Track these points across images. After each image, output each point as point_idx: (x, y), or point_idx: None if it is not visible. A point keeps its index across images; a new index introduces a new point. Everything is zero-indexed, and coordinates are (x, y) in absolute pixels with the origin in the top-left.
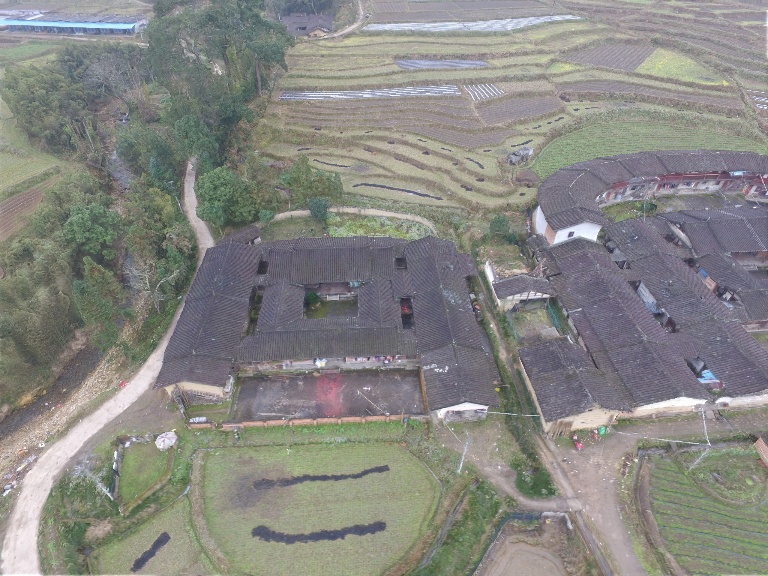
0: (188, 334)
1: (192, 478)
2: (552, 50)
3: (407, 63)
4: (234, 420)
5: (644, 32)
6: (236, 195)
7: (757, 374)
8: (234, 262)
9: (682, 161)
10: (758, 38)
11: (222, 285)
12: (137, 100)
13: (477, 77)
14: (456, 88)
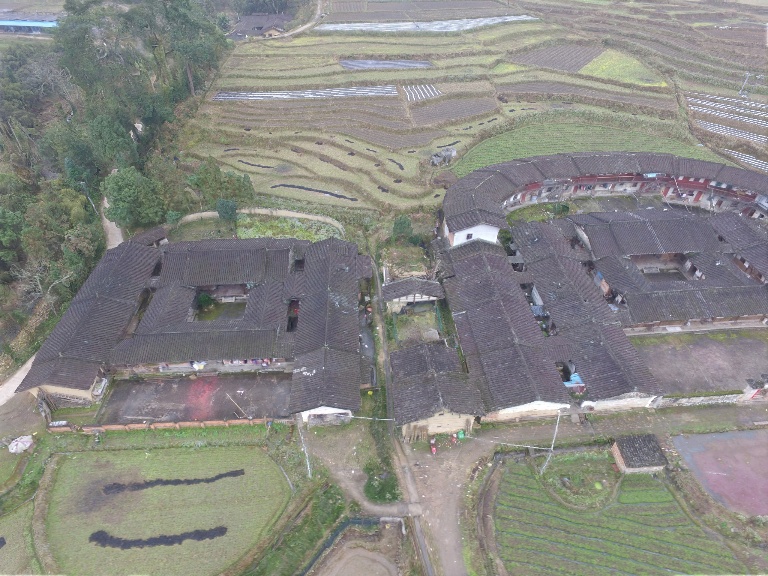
0: (62, 337)
1: (39, 482)
2: (500, 51)
3: (351, 63)
4: (95, 424)
5: (597, 33)
6: (140, 196)
7: (620, 378)
8: (128, 264)
9: (596, 163)
10: (705, 39)
11: (109, 287)
12: (75, 100)
13: (417, 78)
14: (394, 89)
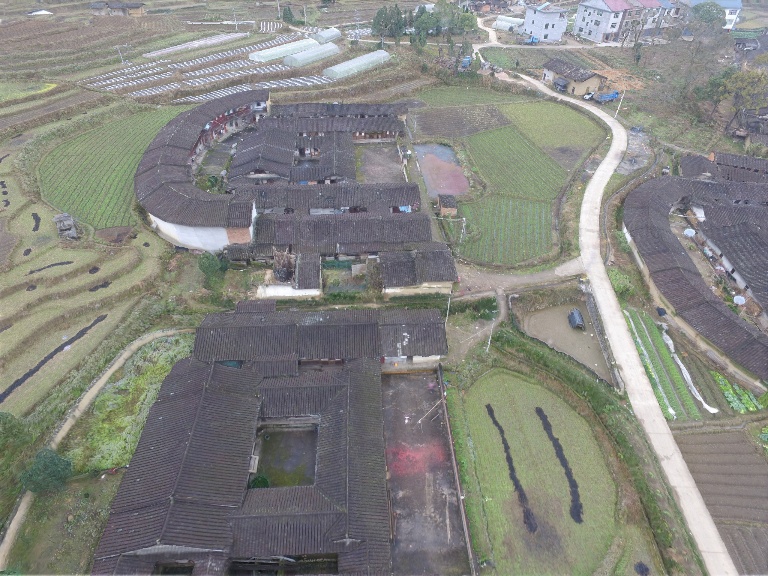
0: None
1: None
2: None
3: None
4: None
5: None
6: None
7: (409, 189)
8: None
9: (181, 138)
10: None
11: None
12: None
13: None
14: None
